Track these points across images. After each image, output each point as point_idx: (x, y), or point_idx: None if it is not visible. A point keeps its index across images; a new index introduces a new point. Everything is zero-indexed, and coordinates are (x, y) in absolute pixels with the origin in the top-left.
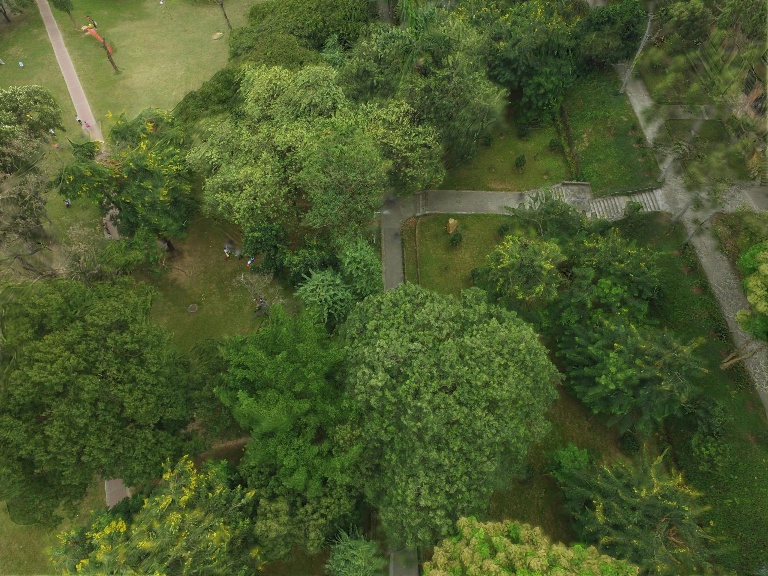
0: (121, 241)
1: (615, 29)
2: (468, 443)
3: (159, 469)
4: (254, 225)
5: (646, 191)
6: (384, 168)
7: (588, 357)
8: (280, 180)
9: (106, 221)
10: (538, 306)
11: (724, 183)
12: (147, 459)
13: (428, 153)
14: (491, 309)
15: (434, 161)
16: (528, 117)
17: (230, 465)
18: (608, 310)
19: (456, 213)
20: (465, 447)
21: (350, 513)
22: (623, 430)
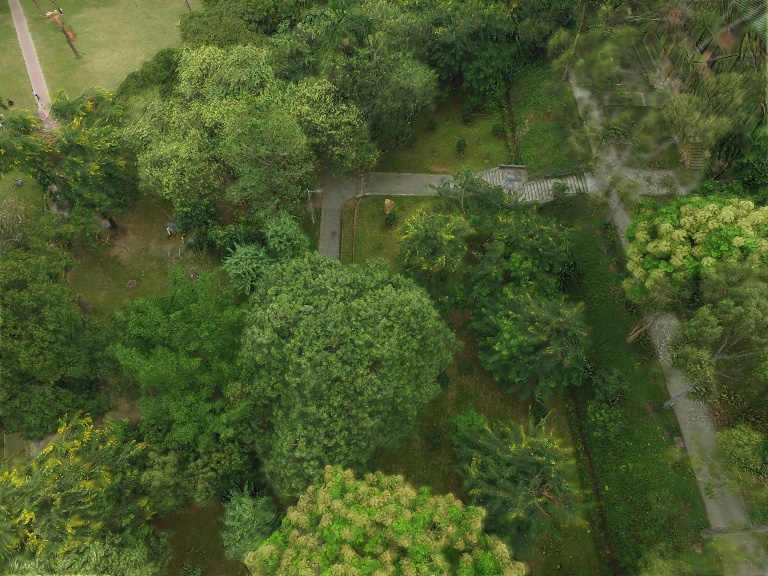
0: (53, 214)
1: (556, 16)
2: (351, 400)
3: (56, 424)
4: (184, 200)
5: (577, 174)
6: (312, 146)
7: (494, 328)
8: (209, 156)
9: (46, 197)
10: (454, 280)
11: (654, 167)
12: (44, 414)
13: (354, 131)
14: (392, 277)
15: (365, 141)
16: (472, 102)
17: (131, 423)
18: (519, 284)
19: (395, 195)
20: (346, 403)
21: (247, 471)
22: (523, 397)
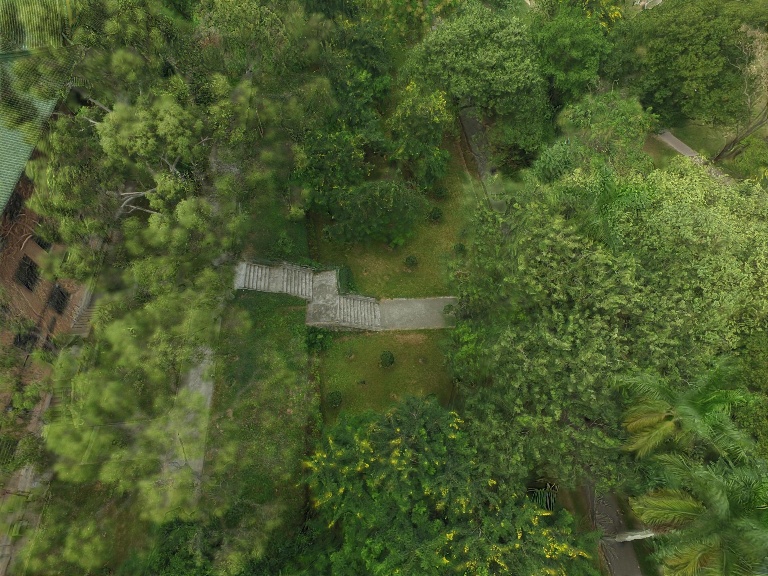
0: None
1: (206, 550)
2: None
3: None
4: None
5: None
6: None
7: None
8: None
9: None
10: None
11: (153, 302)
12: None
13: None
14: None
15: None
16: None
17: None
18: None
19: None
20: None
21: None
22: None
